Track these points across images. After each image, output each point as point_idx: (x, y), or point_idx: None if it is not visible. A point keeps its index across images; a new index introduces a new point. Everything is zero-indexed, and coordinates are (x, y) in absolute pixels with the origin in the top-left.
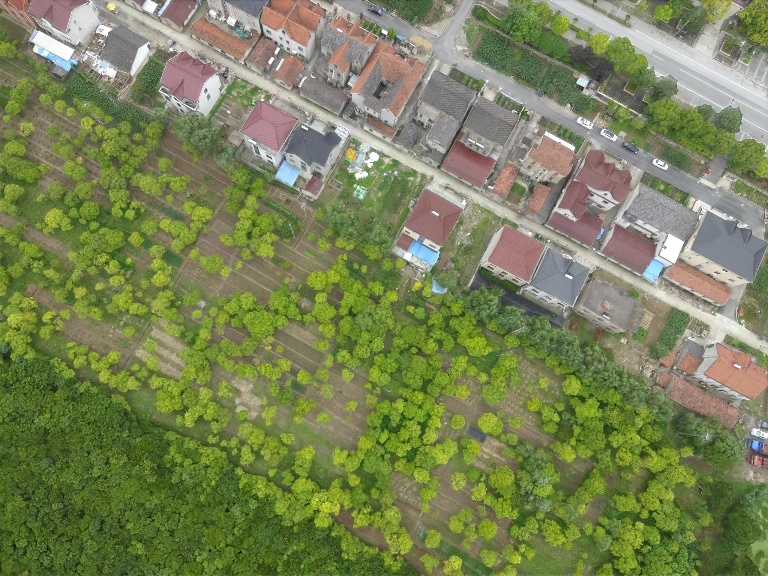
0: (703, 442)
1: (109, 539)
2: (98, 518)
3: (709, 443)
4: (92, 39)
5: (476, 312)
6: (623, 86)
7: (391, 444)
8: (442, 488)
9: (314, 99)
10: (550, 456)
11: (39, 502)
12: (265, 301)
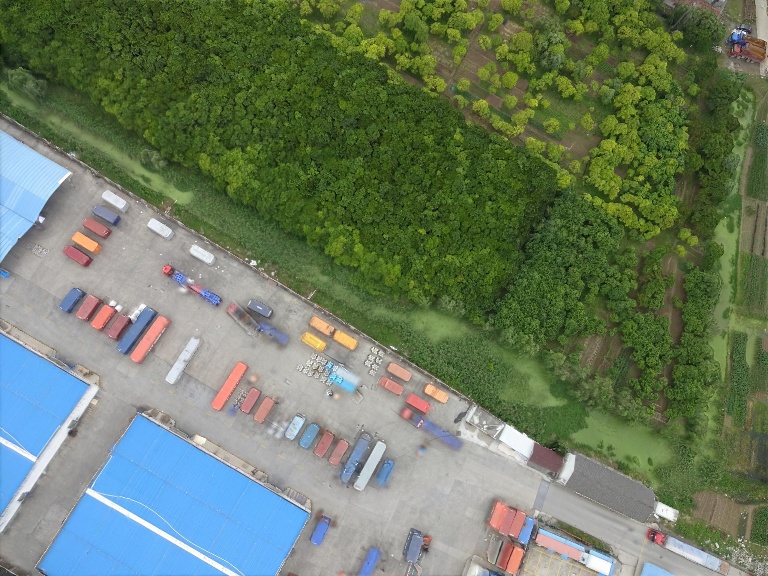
0: (691, 21)
1: (192, 49)
2: (182, 34)
3: (696, 23)
4: None
5: None
6: None
7: (428, 6)
8: (470, 56)
9: None
10: (562, 28)
11: (132, 15)
12: None
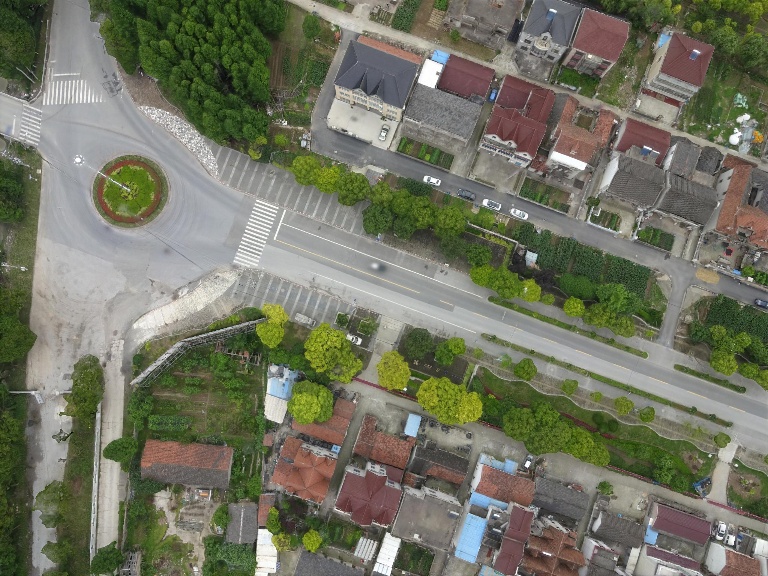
0: None
1: None
2: None
3: None
4: None
5: None
6: None
7: None
8: None
9: None
10: None
11: None
12: None
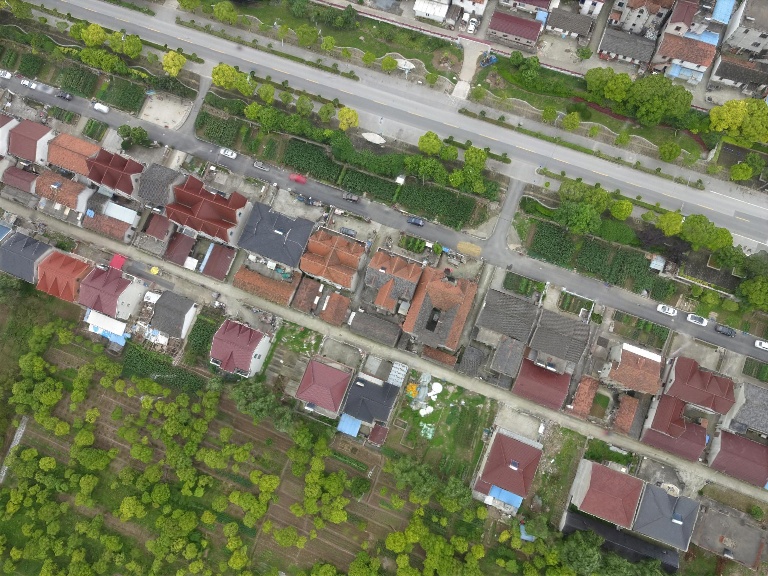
0: None
1: None
2: None
3: None
4: (141, 307)
5: (574, 568)
6: (706, 261)
7: None
8: None
9: (366, 336)
10: None
11: None
12: (345, 565)
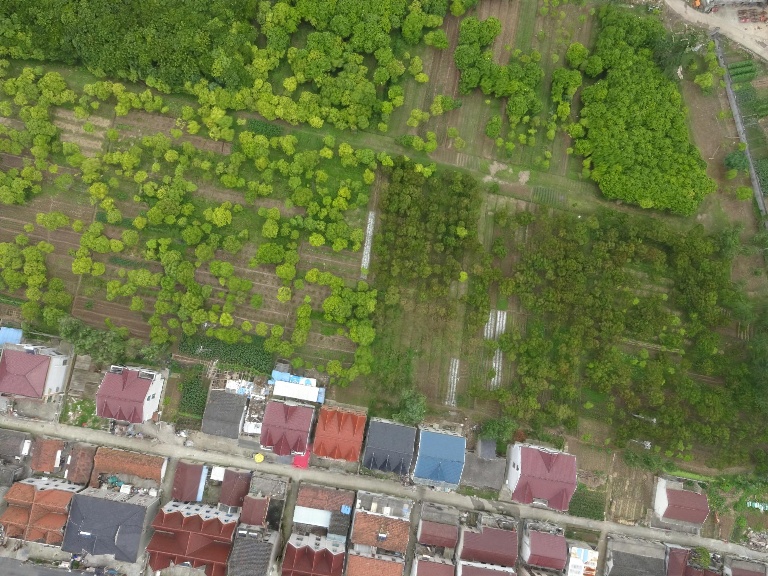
0: None
1: None
2: None
3: None
4: None
5: None
6: None
7: None
8: None
9: (7, 431)
10: None
11: None
12: (4, 206)
